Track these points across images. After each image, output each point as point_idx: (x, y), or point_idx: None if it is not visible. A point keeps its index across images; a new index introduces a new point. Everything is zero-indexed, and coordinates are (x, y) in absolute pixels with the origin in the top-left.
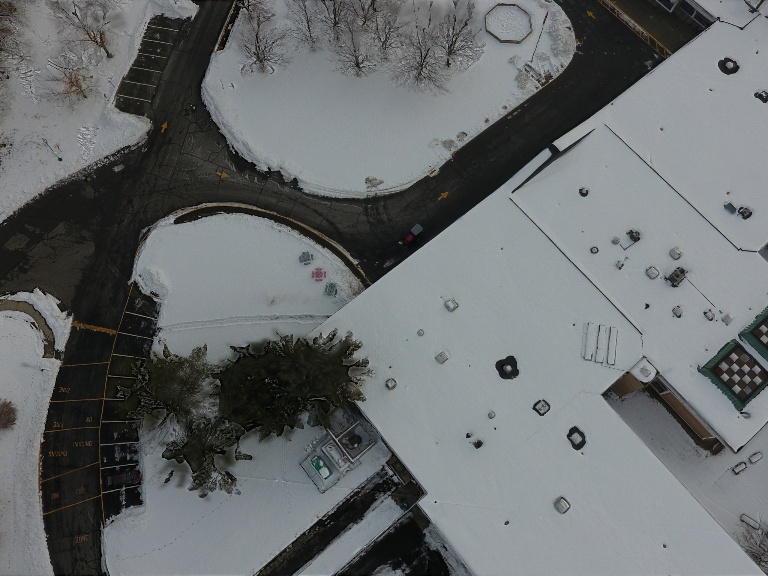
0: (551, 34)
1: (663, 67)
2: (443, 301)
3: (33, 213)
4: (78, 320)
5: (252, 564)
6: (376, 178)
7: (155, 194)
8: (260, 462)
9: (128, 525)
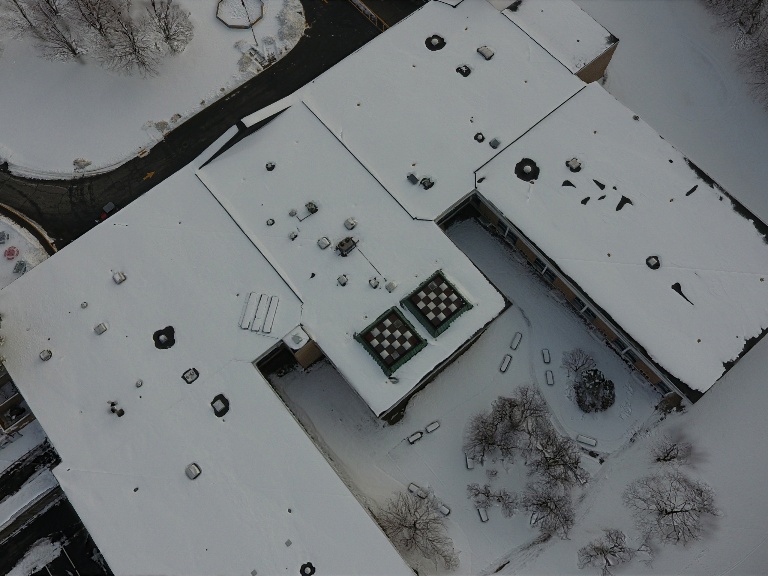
0: (280, 19)
1: (370, 45)
2: (112, 274)
3: None
4: None
5: None
6: (85, 160)
7: None
8: None
9: None
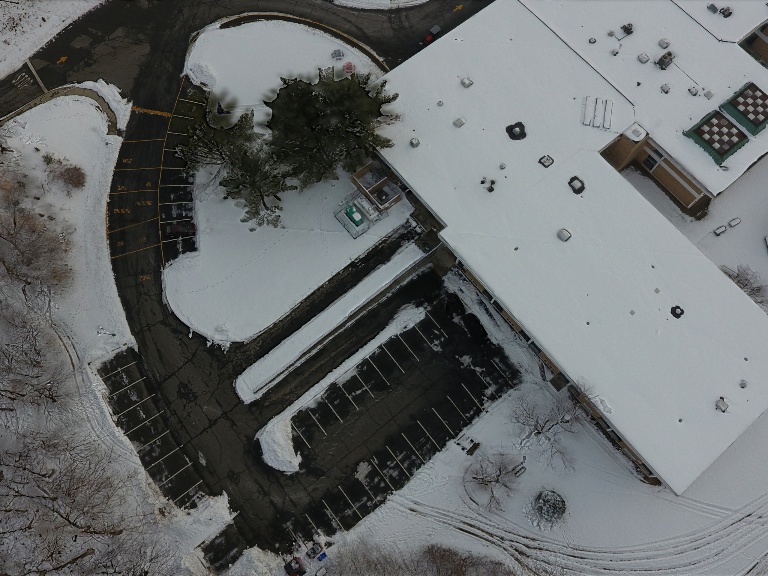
0: None
1: None
2: (460, 80)
3: (95, 19)
4: (137, 105)
5: (294, 296)
6: None
7: (202, 5)
8: (300, 216)
9: (185, 265)
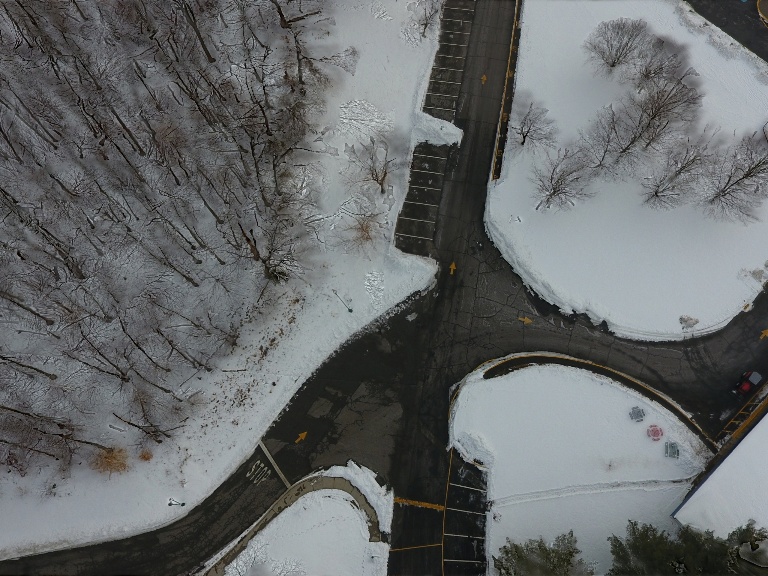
0: None
1: None
2: None
3: (332, 373)
4: (399, 495)
5: None
6: (690, 317)
7: (457, 345)
8: None
9: None
